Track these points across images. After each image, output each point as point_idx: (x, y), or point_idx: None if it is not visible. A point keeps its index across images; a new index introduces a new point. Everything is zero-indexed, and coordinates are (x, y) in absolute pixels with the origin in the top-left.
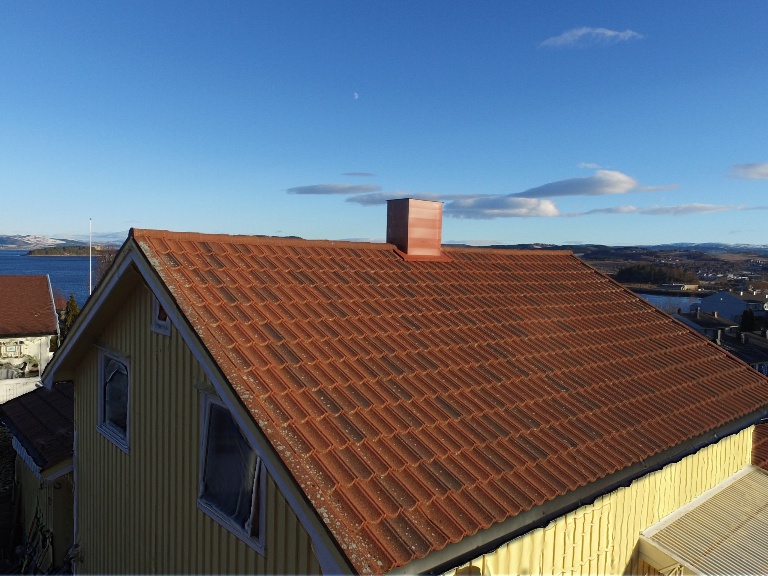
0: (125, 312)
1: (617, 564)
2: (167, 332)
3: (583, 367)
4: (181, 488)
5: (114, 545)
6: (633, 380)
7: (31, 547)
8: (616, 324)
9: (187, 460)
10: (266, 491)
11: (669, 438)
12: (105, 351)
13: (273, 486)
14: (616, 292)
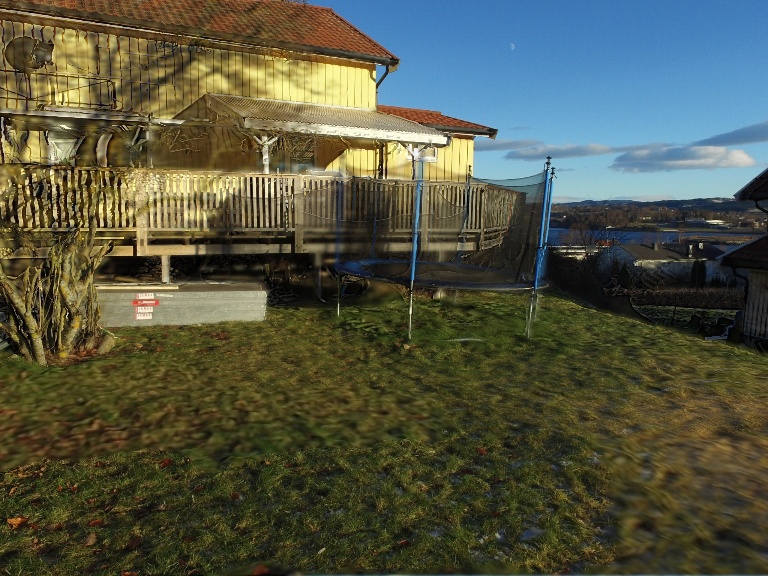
0: None
1: (182, 100)
2: None
3: (202, 14)
4: None
5: None
6: (237, 23)
7: None
8: (287, 20)
9: None
10: None
11: (205, 26)
12: None
13: None
14: (334, 21)
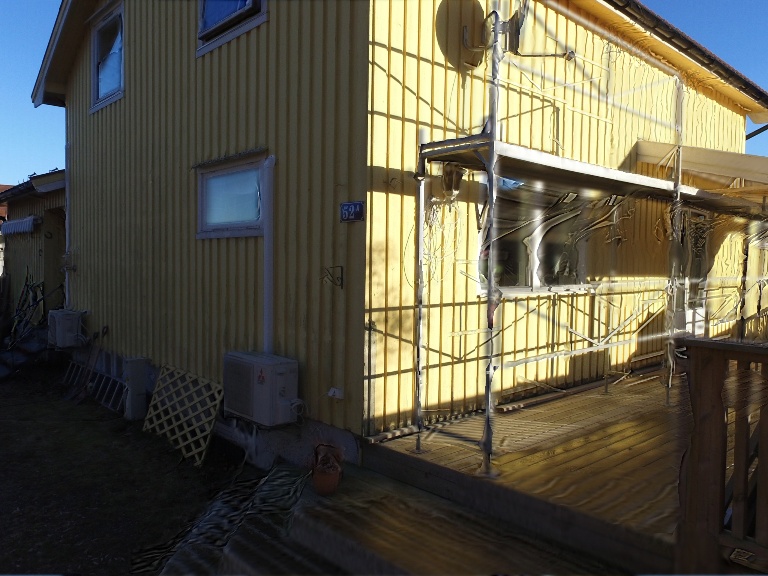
0: None
1: (616, 150)
2: None
3: None
4: (179, 61)
5: (109, 210)
6: None
7: None
8: None
9: (185, 24)
10: None
11: None
12: (98, 22)
13: None
14: None
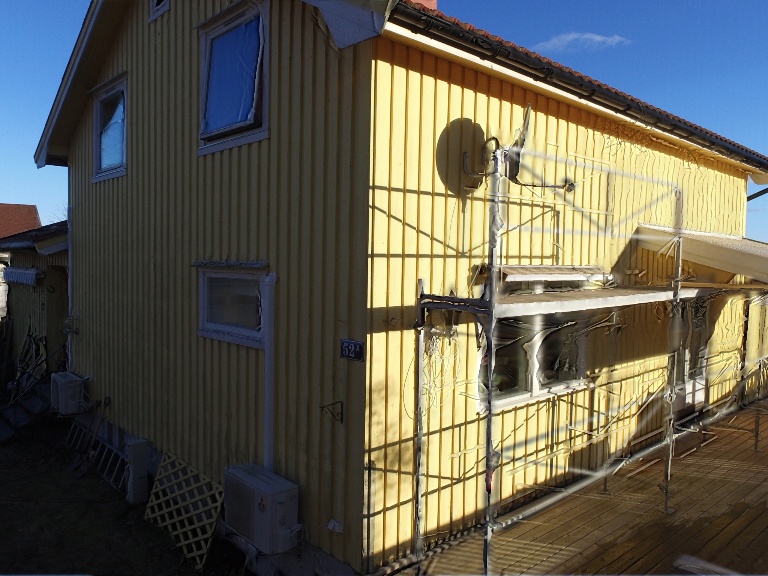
0: (121, 32)
1: (617, 239)
2: (165, 7)
3: None
4: (181, 154)
5: (111, 282)
6: None
7: (24, 362)
8: None
9: (187, 119)
10: (269, 71)
11: None
12: (101, 94)
13: (276, 57)
14: None
